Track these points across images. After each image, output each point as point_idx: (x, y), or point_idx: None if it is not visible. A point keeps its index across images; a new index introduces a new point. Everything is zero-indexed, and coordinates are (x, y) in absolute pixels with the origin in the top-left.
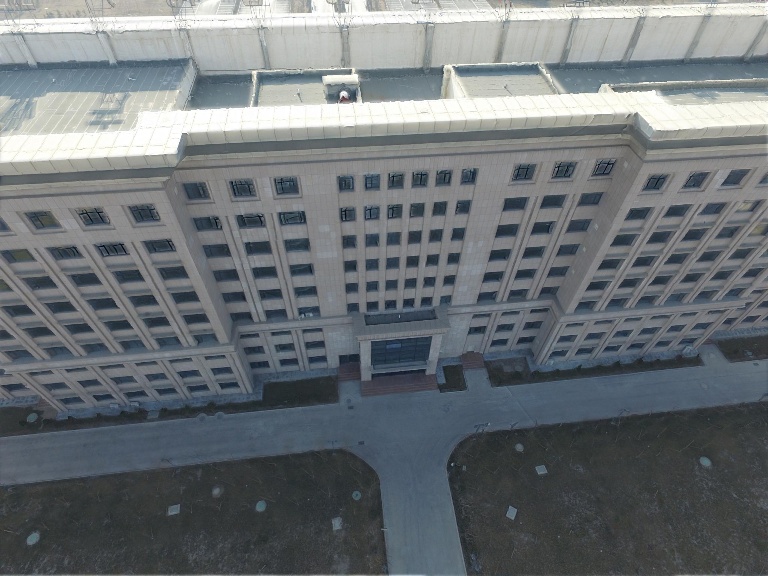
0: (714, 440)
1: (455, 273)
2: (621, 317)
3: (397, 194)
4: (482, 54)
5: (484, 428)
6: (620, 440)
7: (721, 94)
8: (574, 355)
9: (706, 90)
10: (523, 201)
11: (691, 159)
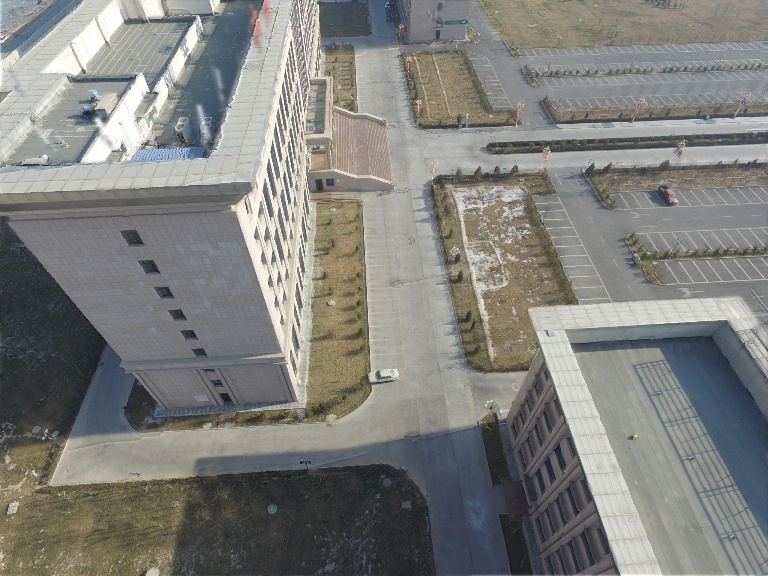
0: None
1: None
2: None
3: None
4: None
5: None
6: None
7: (164, 55)
8: None
9: (174, 52)
10: None
11: None
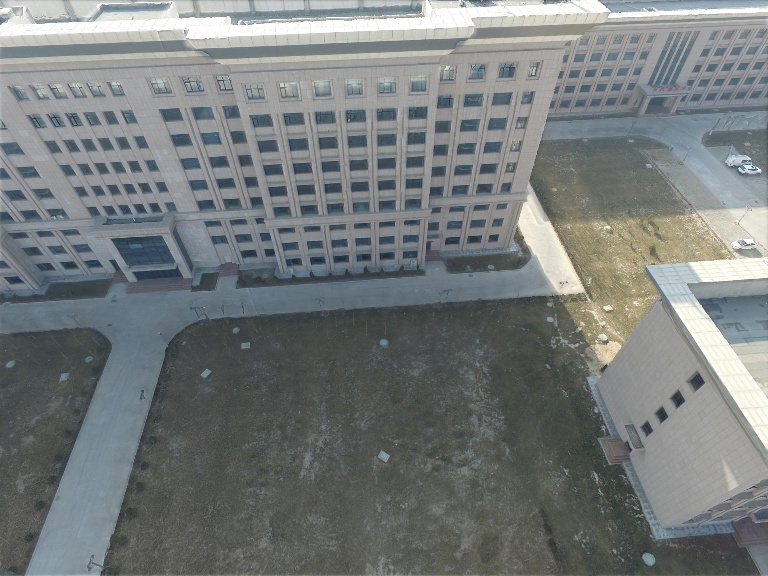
0: (401, 328)
1: (163, 180)
2: (320, 224)
3: (66, 103)
4: (181, 4)
5: (203, 312)
6: (321, 327)
7: None
8: (310, 265)
9: None
10: (180, 113)
11: (270, 71)
